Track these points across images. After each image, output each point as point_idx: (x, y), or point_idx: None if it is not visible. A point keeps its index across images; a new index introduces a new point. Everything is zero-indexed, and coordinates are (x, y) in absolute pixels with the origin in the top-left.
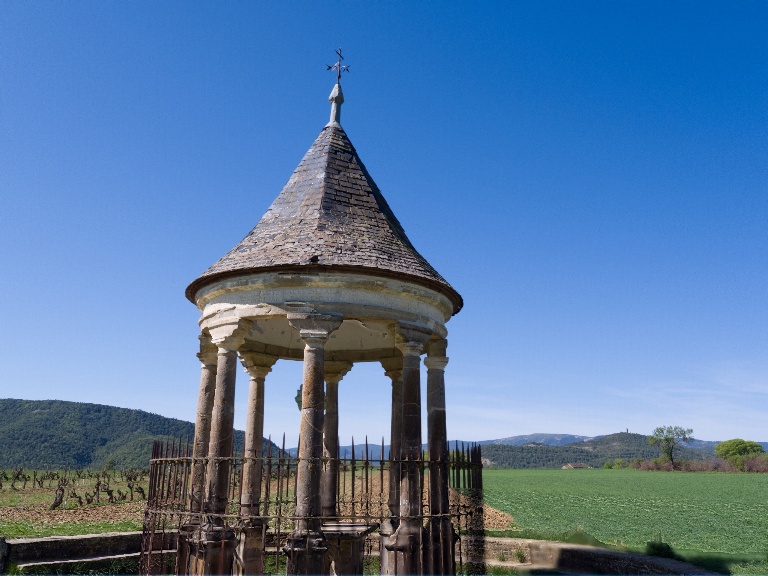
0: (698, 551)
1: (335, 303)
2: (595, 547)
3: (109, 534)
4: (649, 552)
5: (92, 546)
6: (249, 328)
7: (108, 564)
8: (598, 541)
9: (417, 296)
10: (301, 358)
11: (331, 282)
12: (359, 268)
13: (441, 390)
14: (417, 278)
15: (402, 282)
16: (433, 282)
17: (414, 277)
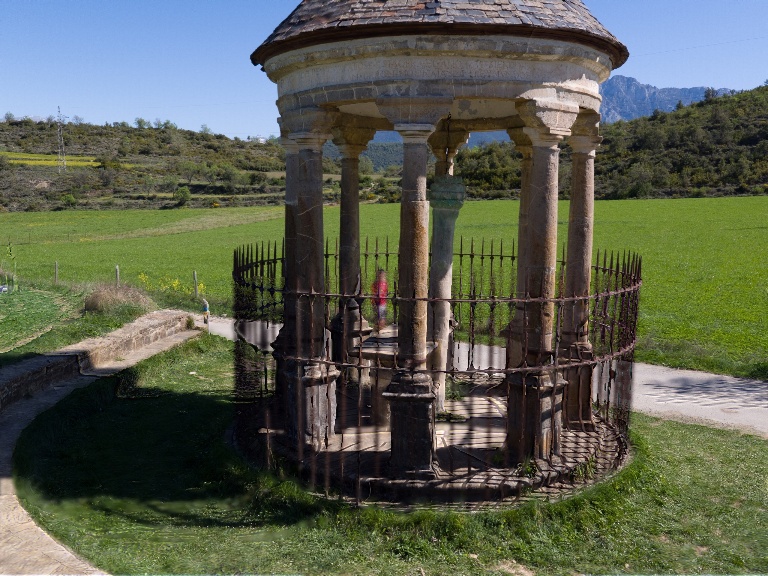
0: None
1: None
2: None
3: None
4: None
5: None
6: (511, 136)
7: None
8: None
9: None
10: None
11: None
12: None
13: None
14: None
15: None
16: None
17: None
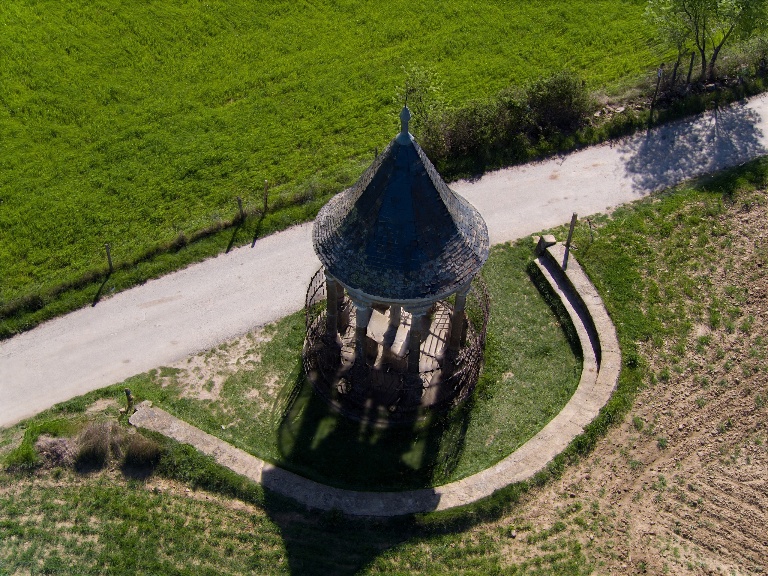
0: (345, 572)
1: None
2: (389, 512)
3: (584, 290)
4: (338, 509)
5: None
6: None
7: None
8: (394, 518)
9: None
10: None
11: None
12: None
13: None
14: None
15: None
16: None
17: None
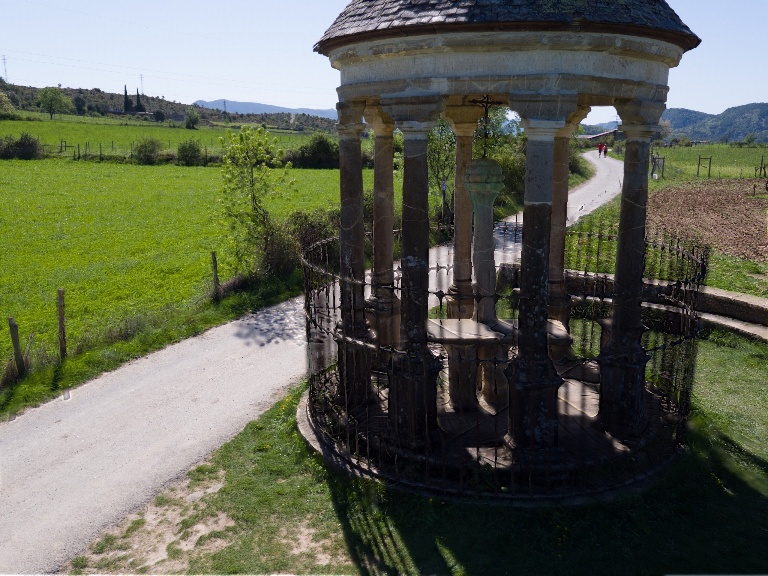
0: None
1: (340, 87)
2: None
3: None
4: None
5: (590, 285)
6: (376, 112)
7: (586, 304)
8: None
9: (403, 52)
10: (606, 104)
11: (335, 63)
12: (331, 42)
13: (530, 174)
14: (378, 31)
15: (370, 42)
16: (405, 26)
17: (374, 31)
